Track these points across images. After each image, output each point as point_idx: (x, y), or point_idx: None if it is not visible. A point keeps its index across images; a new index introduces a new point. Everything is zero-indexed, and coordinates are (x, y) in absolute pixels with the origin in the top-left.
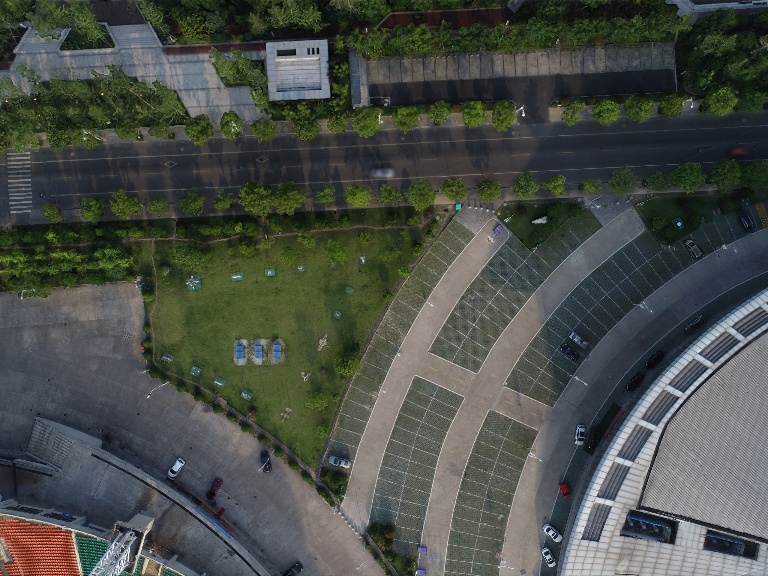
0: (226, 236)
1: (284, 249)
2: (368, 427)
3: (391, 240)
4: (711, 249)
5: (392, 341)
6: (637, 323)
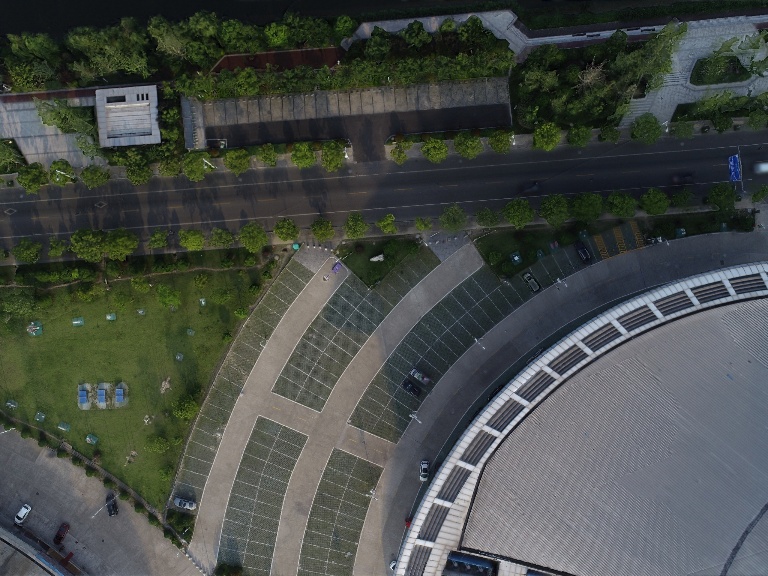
0: (66, 282)
1: (117, 295)
2: (213, 468)
3: (230, 281)
4: (551, 282)
5: (235, 382)
6: (479, 358)
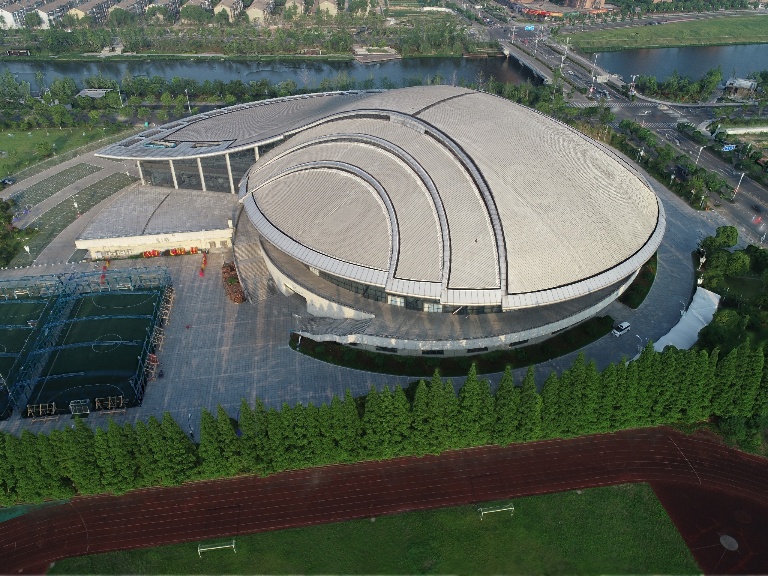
0: None
1: None
2: (37, 175)
3: None
4: None
5: None
6: None
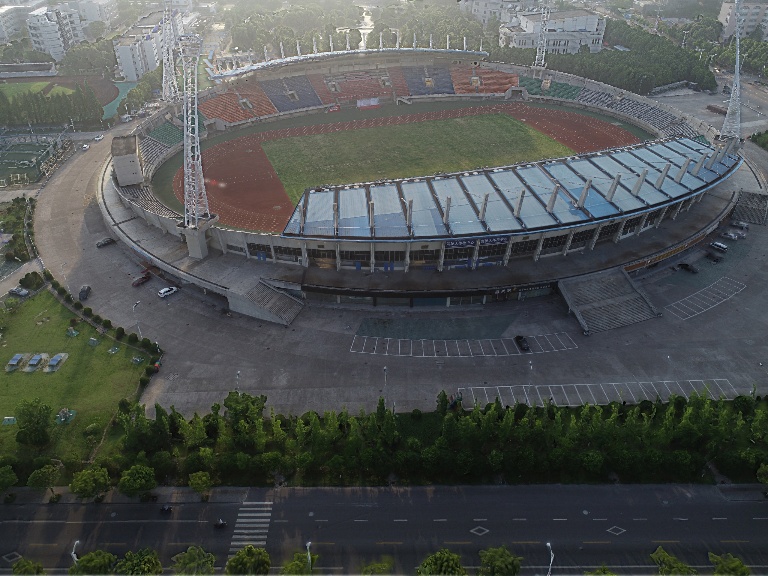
0: None
1: None
2: None
3: None
4: None
5: None
6: None
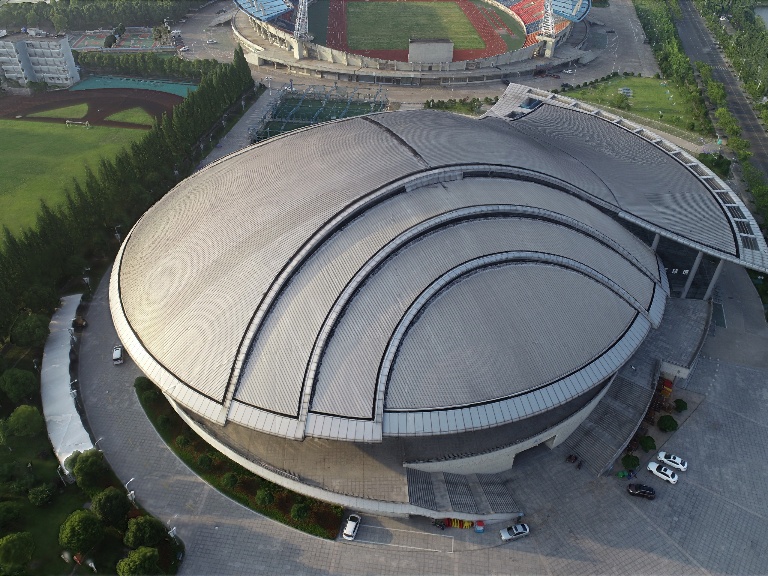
0: None
1: None
2: None
3: None
4: None
5: None
6: None
